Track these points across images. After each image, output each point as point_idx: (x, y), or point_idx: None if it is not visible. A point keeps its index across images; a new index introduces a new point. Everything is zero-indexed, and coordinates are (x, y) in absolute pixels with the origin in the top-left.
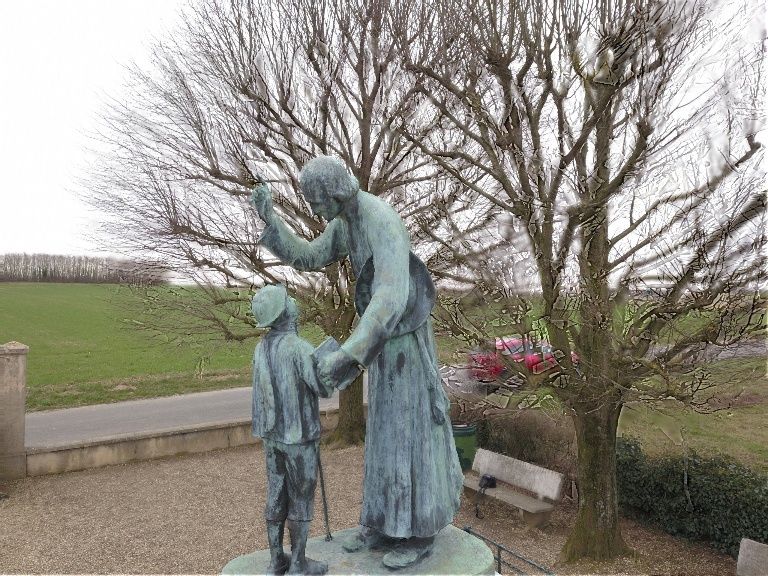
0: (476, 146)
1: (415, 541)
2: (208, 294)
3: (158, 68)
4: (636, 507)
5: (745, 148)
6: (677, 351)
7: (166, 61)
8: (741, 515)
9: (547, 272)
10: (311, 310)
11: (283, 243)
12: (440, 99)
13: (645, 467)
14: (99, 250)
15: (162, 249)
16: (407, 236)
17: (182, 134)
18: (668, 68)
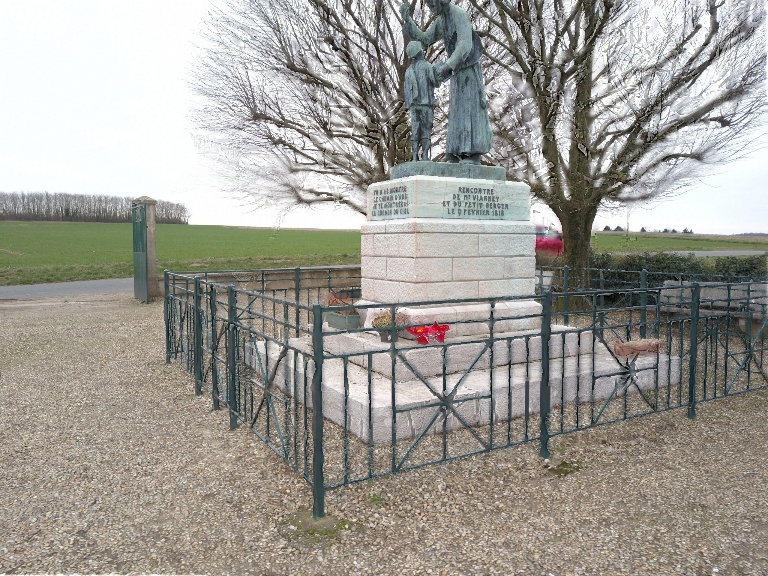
0: (498, 30)
1: (472, 158)
2: (285, 164)
3: None
4: (606, 296)
5: (691, 29)
6: (631, 166)
7: None
8: None
9: (546, 119)
10: (366, 174)
11: (413, 31)
12: None
13: (612, 264)
14: None
15: None
16: None
17: (264, 35)
18: None
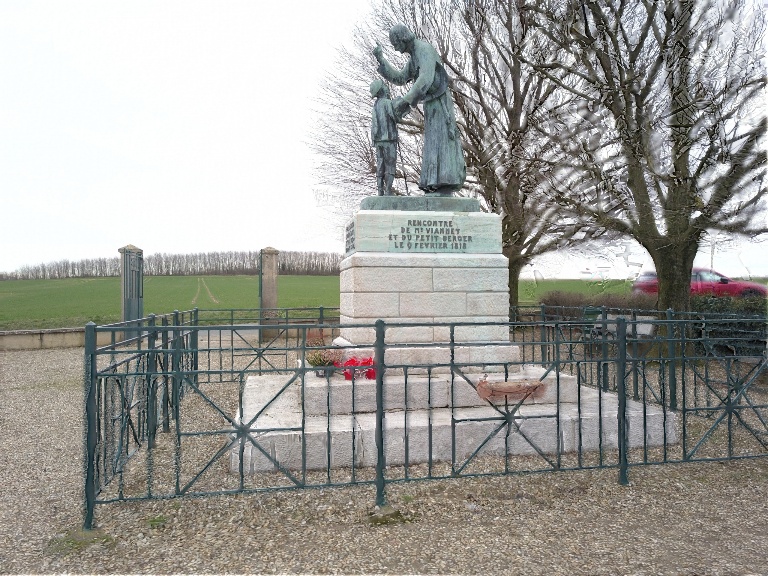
0: None
1: (440, 190)
2: None
3: (358, 47)
4: (726, 347)
5: None
6: None
7: (362, 39)
8: None
9: None
10: None
11: (387, 71)
12: None
13: None
14: (321, 183)
15: None
16: (437, 56)
17: None
18: None
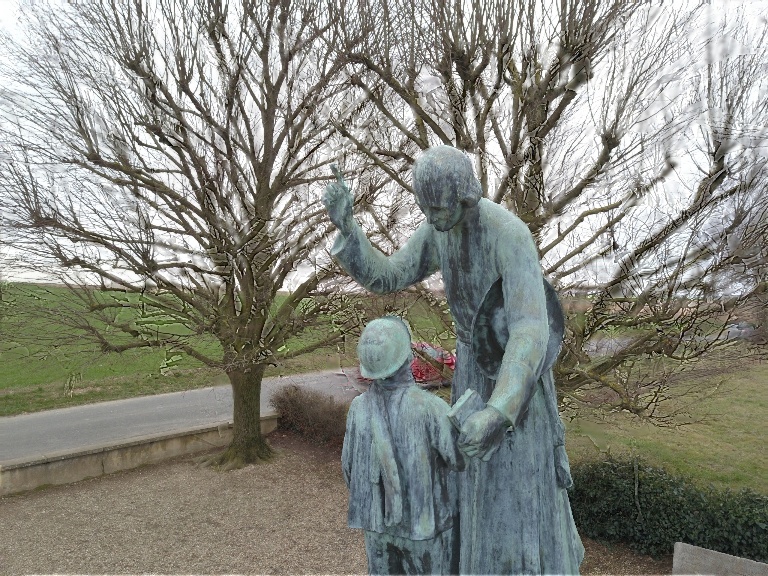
0: (414, 147)
1: None
2: (81, 299)
3: (21, 28)
4: None
5: None
6: (615, 362)
7: (37, 20)
8: (660, 516)
9: None
10: (209, 317)
11: (363, 258)
12: (377, 94)
13: None
14: None
15: (20, 244)
16: None
17: (52, 110)
18: (636, 82)
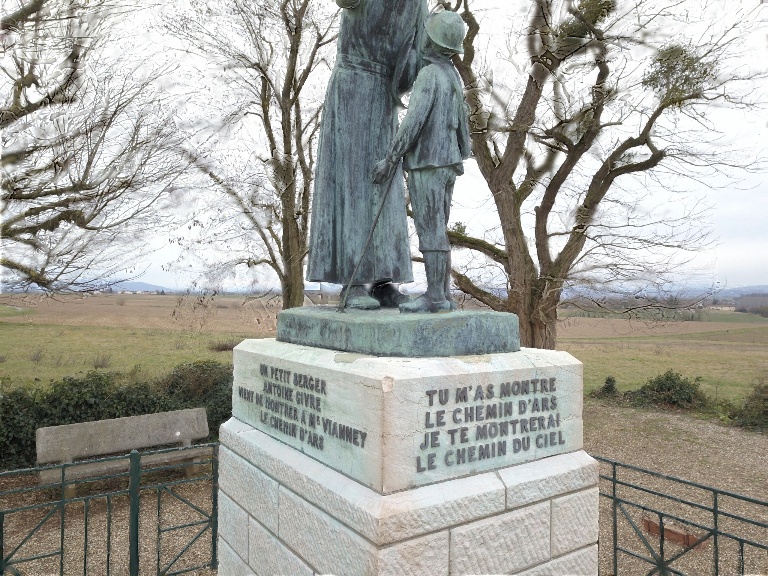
0: None
1: None
2: None
3: None
4: None
5: None
6: None
7: None
8: None
9: None
10: None
11: None
12: None
13: None
14: None
15: None
16: None
17: None
18: None
